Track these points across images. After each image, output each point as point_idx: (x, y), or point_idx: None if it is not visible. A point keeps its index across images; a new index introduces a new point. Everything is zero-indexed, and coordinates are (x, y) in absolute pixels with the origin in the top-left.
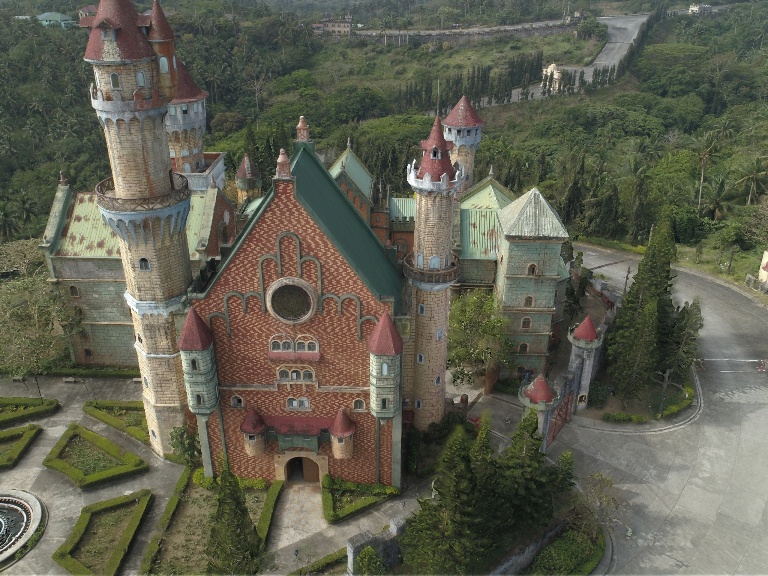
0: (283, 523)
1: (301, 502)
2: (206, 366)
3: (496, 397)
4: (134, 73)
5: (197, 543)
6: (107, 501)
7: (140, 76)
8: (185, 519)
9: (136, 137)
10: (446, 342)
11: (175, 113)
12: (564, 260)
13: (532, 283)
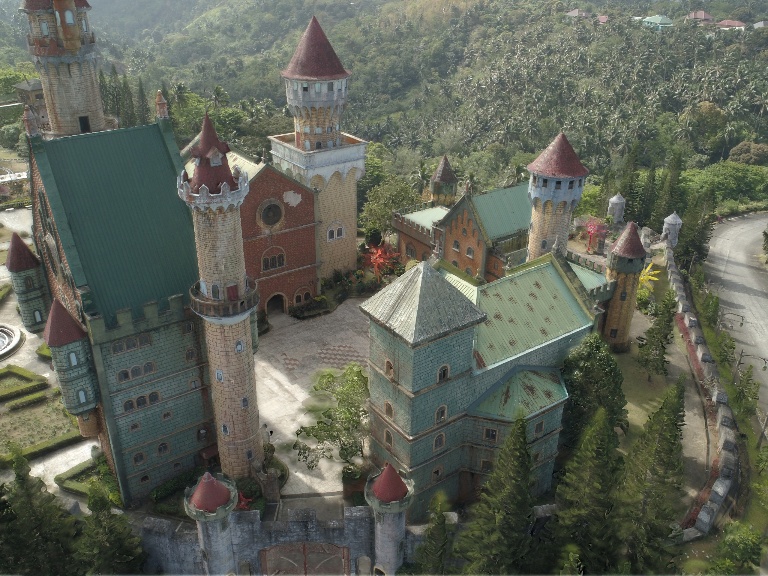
0: (48, 460)
1: (78, 456)
2: (18, 287)
3: (343, 506)
4: (39, 22)
5: (1, 430)
6: (24, 370)
7: (45, 26)
8: (27, 412)
9: (46, 79)
10: (238, 391)
11: (297, 88)
12: (604, 410)
13: (391, 387)
